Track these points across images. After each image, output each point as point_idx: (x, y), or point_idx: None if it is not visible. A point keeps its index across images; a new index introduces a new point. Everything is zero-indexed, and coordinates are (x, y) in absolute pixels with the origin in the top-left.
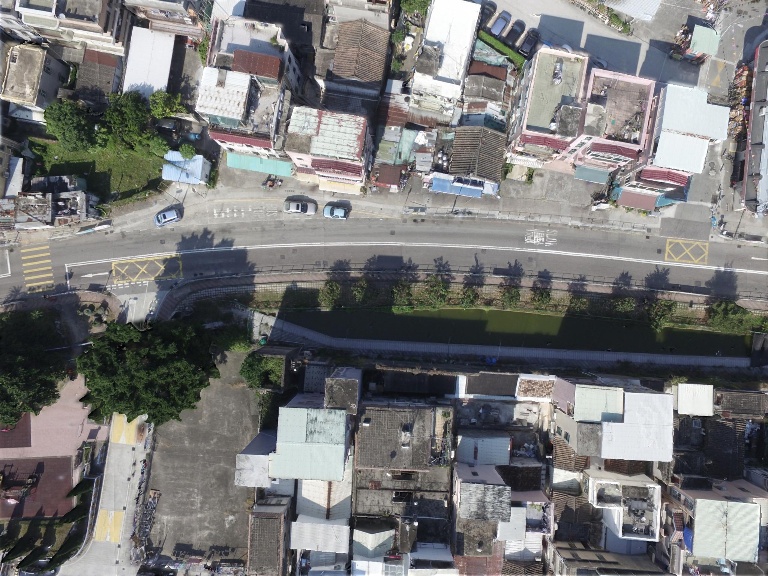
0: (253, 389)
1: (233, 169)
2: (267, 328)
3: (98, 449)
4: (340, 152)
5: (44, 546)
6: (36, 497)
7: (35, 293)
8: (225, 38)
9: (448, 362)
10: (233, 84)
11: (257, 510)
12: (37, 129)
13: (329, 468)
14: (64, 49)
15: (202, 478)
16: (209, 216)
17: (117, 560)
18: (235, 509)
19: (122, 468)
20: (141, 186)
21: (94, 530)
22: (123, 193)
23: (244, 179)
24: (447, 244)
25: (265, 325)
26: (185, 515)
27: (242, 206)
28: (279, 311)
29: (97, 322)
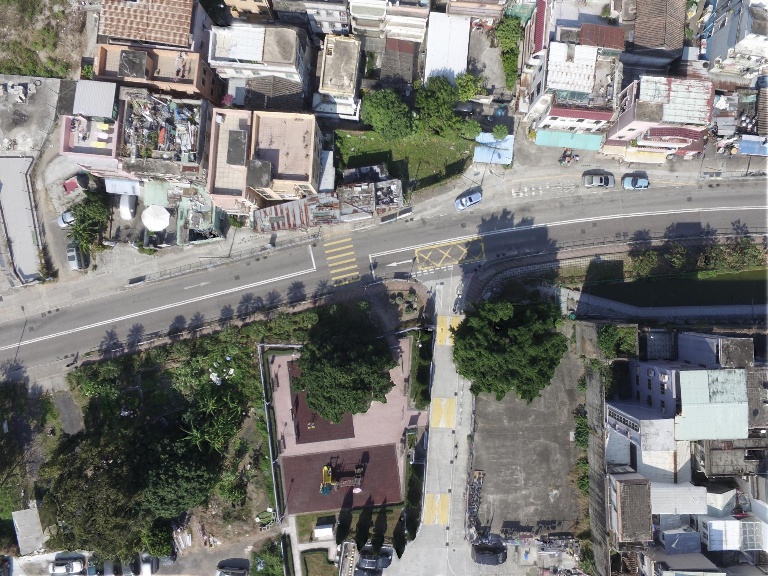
0: (609, 359)
1: (528, 148)
2: (573, 303)
3: (419, 434)
4: (692, 118)
5: (380, 533)
6: (364, 486)
7: (342, 286)
8: (554, 14)
9: (755, 323)
10: (582, 58)
11: (619, 478)
12: (330, 123)
13: (734, 427)
14: (366, 39)
15: (523, 455)
16: (508, 196)
17: (447, 542)
18: (558, 483)
19: (444, 451)
20: (440, 171)
21: (422, 514)
22: (422, 180)
23: (540, 157)
24: (744, 207)
25: (571, 300)
26: (510, 493)
27: (540, 184)
28: (583, 285)
29: (411, 309)
